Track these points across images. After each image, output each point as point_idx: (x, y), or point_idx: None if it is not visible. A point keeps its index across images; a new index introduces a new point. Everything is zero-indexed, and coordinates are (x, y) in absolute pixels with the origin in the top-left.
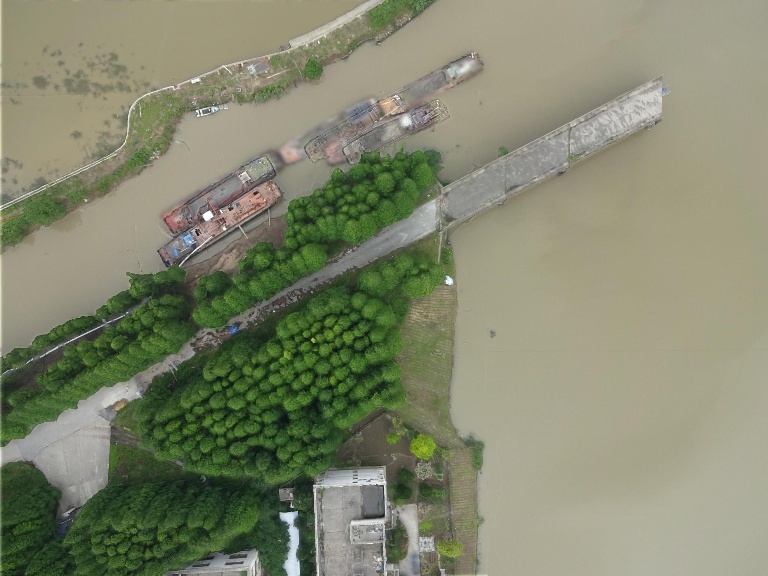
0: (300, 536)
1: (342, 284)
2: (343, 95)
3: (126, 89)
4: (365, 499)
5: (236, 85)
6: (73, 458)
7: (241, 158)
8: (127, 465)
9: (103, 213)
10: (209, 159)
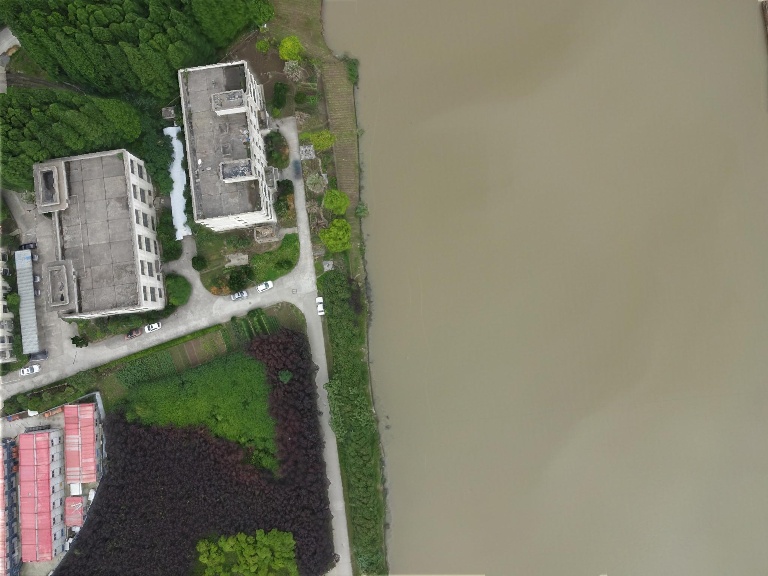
0: (185, 150)
1: None
2: None
3: None
4: (228, 79)
5: None
6: None
7: None
8: None
9: None
10: None
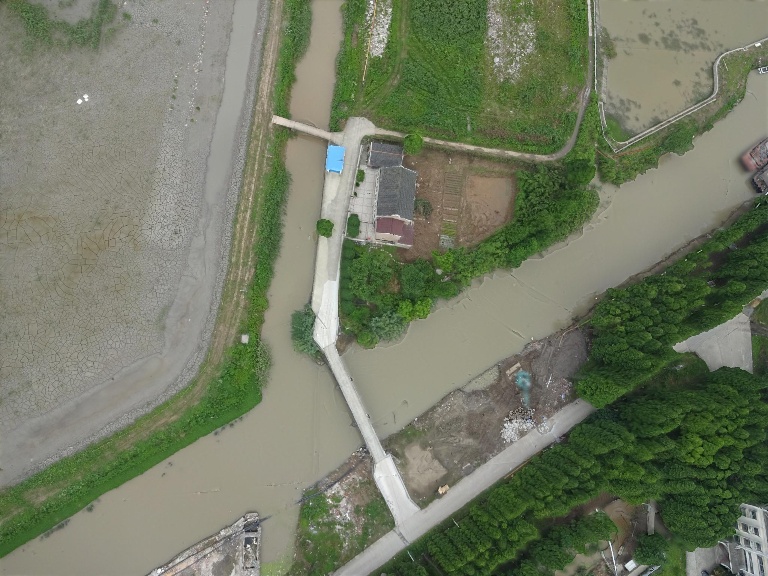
0: None
1: None
2: None
3: (707, 48)
4: None
5: None
6: (726, 348)
7: None
8: (767, 353)
9: (691, 150)
10: None
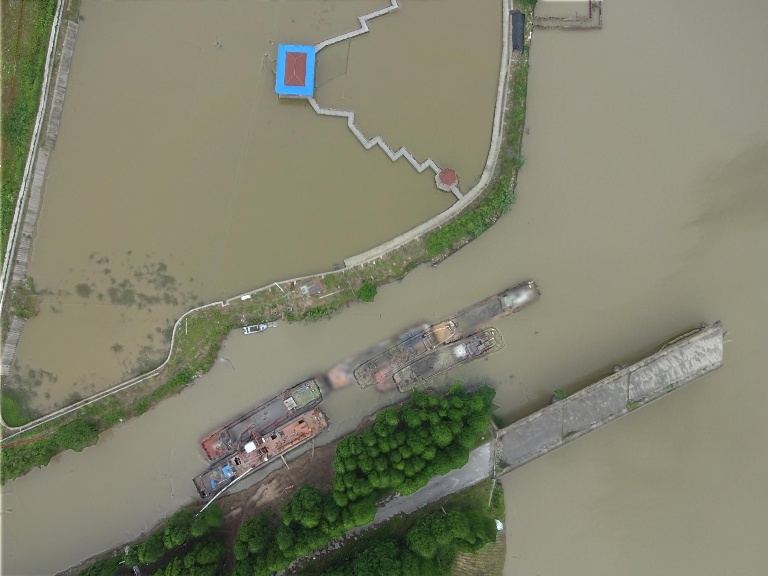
0: None
1: (388, 532)
2: (396, 317)
3: (173, 301)
4: None
5: (287, 304)
6: None
7: (287, 380)
8: None
9: (137, 429)
10: (254, 380)
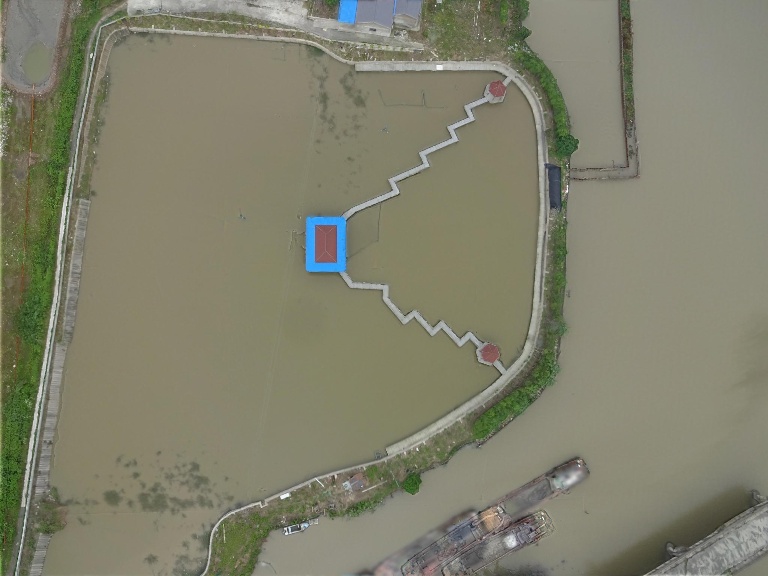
0: None
1: None
2: (442, 505)
3: (208, 504)
4: None
5: (329, 500)
6: None
7: None
8: None
9: None
10: None
